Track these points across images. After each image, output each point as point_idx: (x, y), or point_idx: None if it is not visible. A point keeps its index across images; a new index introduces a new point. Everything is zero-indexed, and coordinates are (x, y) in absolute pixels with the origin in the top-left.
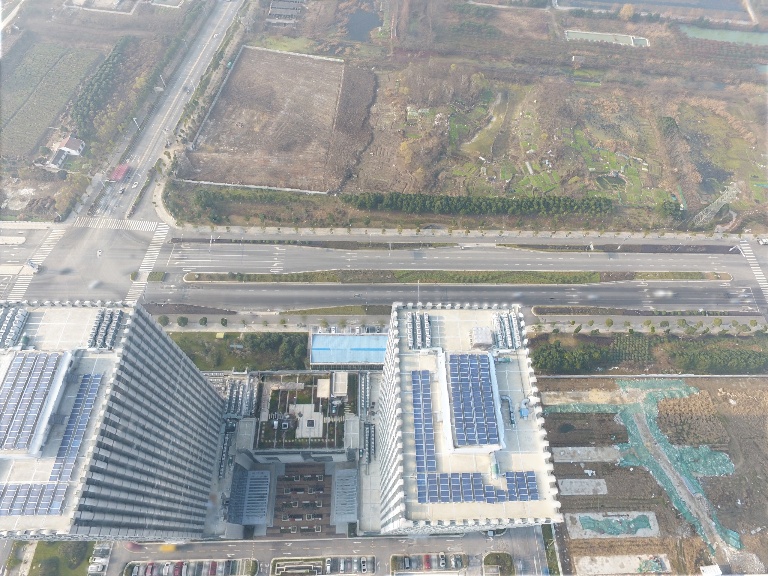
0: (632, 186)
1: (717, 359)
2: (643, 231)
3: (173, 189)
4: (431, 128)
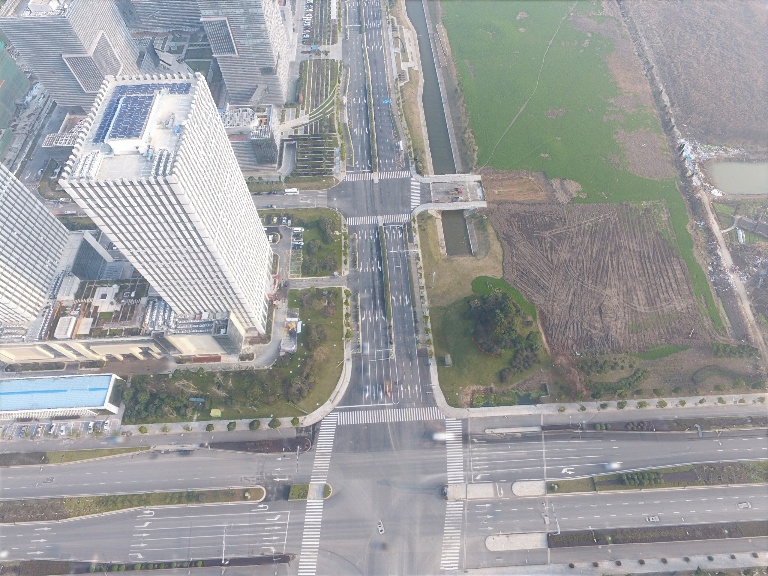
0: None
1: None
2: None
3: None
4: None
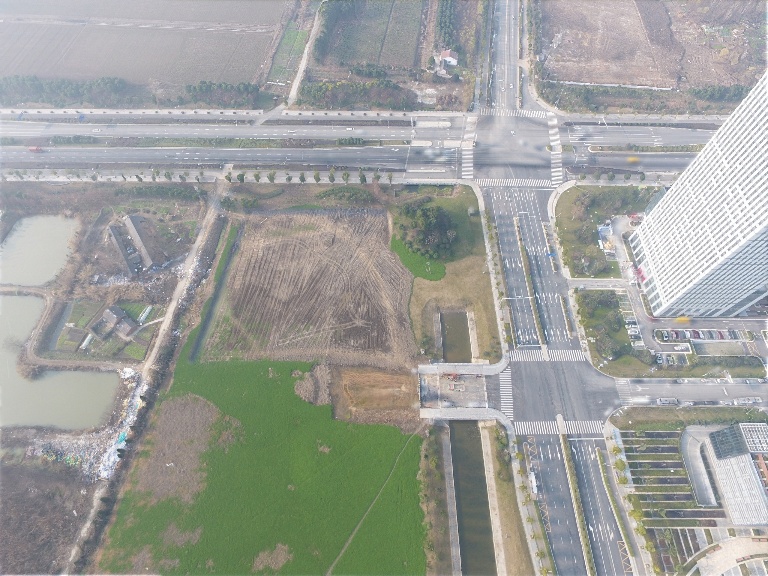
0: None
1: None
2: None
3: (546, 87)
4: (732, 41)
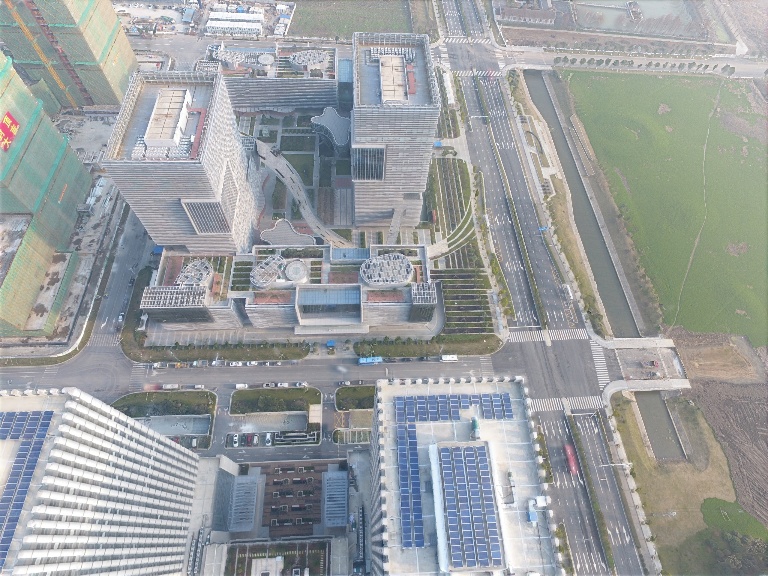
0: None
1: None
2: None
3: None
4: None
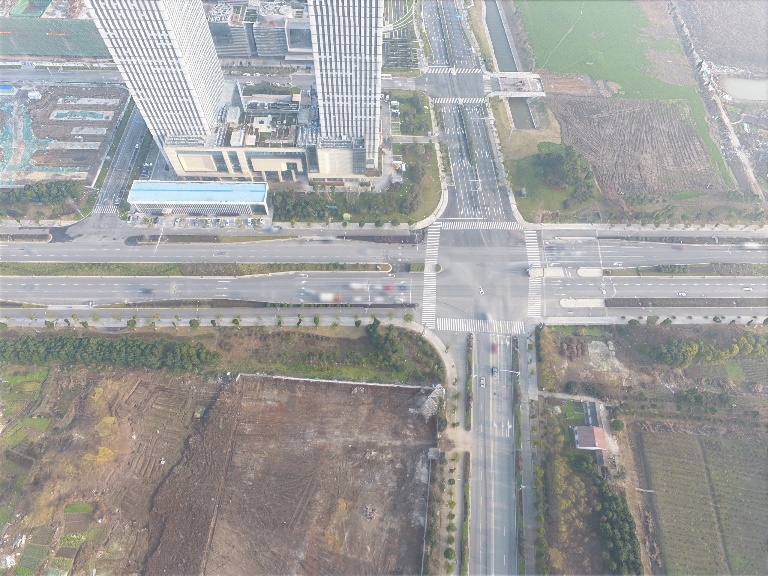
0: None
1: None
2: None
3: None
4: (39, 528)
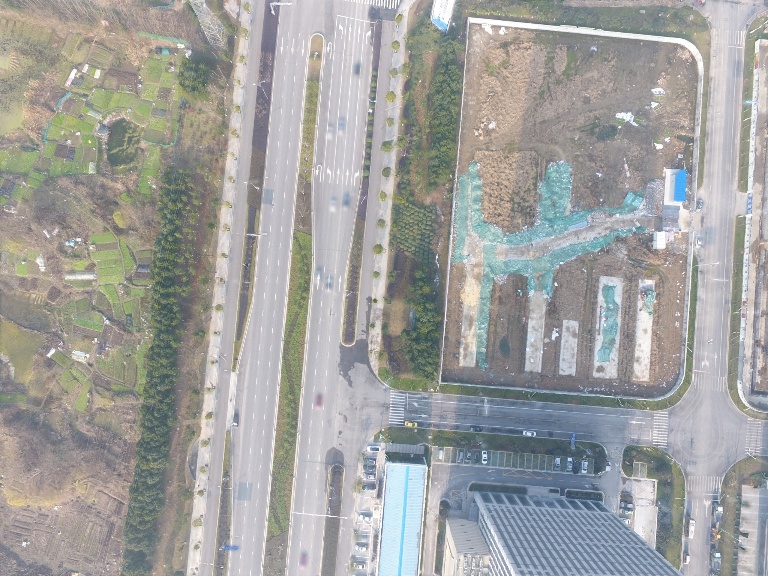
0: (133, 112)
1: (447, 130)
2: (227, 133)
3: None
4: None
